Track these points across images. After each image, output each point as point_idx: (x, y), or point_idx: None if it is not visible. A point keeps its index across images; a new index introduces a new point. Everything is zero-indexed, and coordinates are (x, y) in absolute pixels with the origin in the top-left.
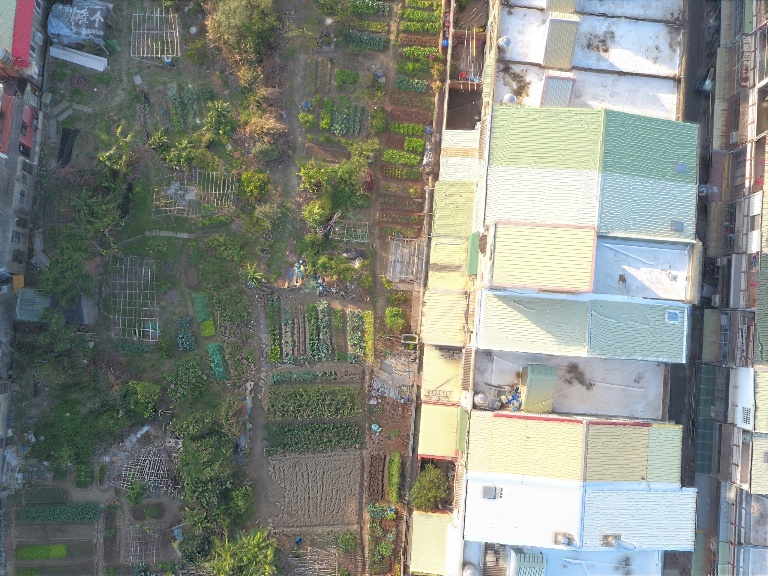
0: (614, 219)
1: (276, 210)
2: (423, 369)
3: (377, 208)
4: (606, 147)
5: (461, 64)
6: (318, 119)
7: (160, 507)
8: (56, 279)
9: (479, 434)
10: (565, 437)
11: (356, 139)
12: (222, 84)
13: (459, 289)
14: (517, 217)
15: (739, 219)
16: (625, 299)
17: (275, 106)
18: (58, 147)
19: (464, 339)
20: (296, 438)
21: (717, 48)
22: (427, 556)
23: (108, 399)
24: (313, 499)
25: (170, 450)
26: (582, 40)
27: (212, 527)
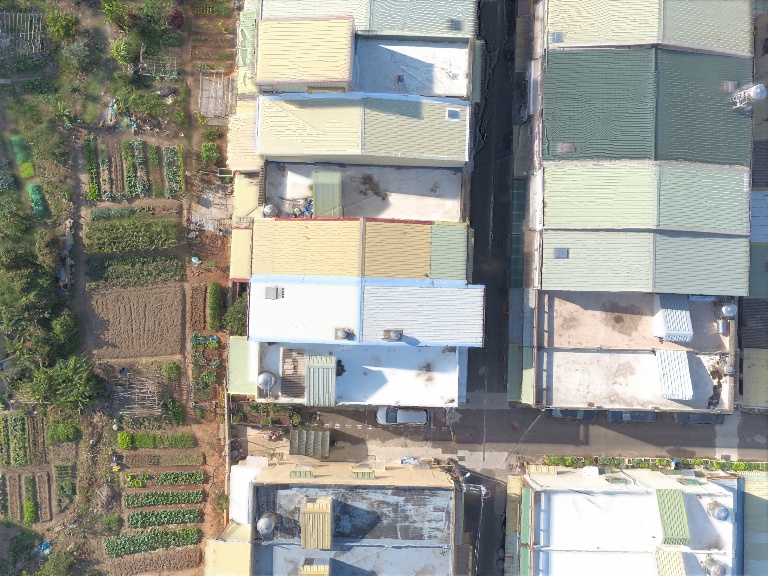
0: (396, 23)
1: (83, 48)
2: (235, 198)
3: (190, 46)
4: None
5: None
6: None
7: None
8: None
9: (263, 239)
10: (345, 236)
11: None
12: None
13: None
14: None
15: (537, 24)
16: (400, 97)
17: None
18: None
19: None
20: (117, 272)
21: None
22: (244, 378)
23: None
24: (136, 331)
25: None
26: None
27: (34, 356)
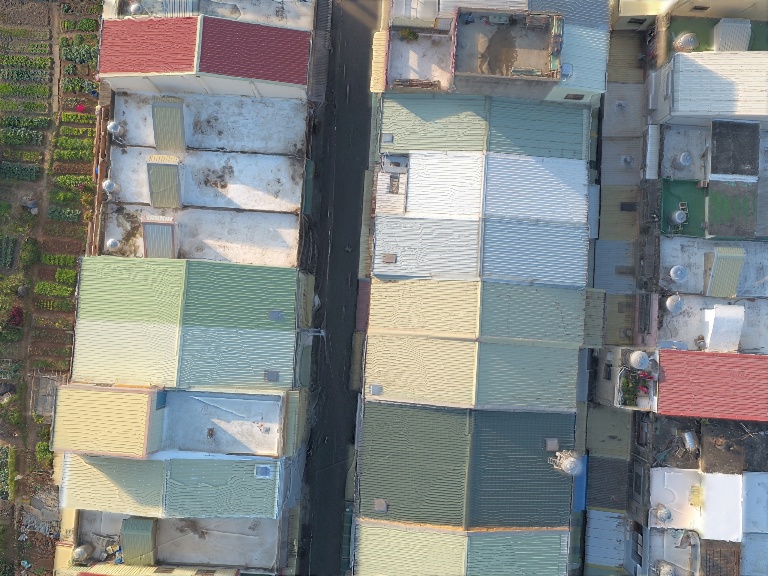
0: (211, 368)
1: None
2: None
3: (28, 341)
4: (187, 300)
5: None
6: None
7: None
8: None
9: None
10: None
11: (8, 272)
12: None
13: None
14: (94, 375)
15: None
16: (206, 456)
17: None
18: None
19: None
20: None
21: (365, 171)
22: None
23: None
24: None
25: None
26: (200, 176)
27: None
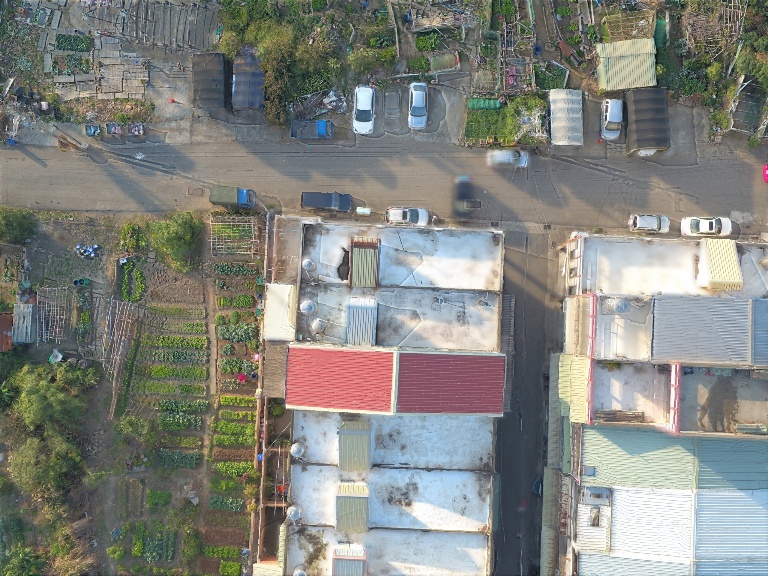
0: None
1: None
2: None
3: None
4: None
5: (275, 485)
6: (130, 544)
7: None
8: None
9: None
10: None
11: (170, 564)
12: (31, 513)
13: None
14: None
15: None
16: None
17: (83, 539)
18: None
19: None
20: None
21: (544, 467)
22: None
23: None
24: None
25: None
26: (383, 494)
27: None
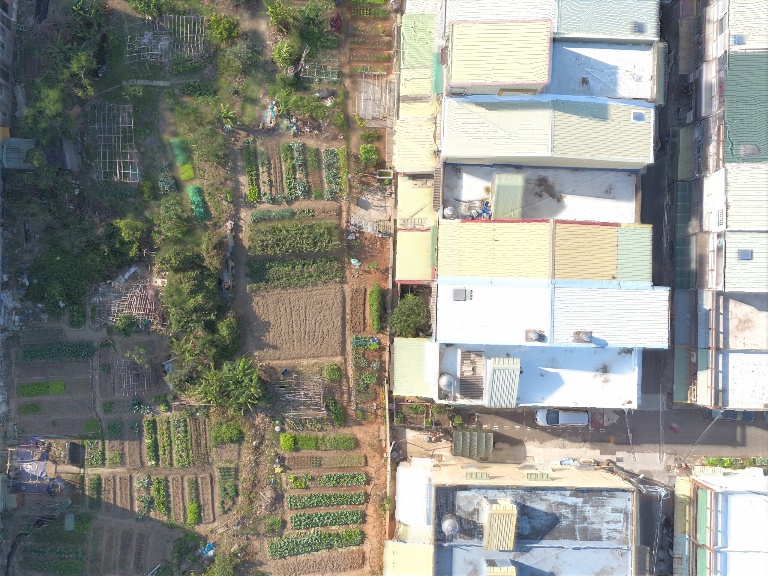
0: (577, 25)
1: (246, 50)
2: (398, 200)
3: (347, 48)
4: None
5: None
6: None
7: (150, 344)
8: (35, 118)
9: (448, 241)
10: (533, 238)
11: None
12: None
13: (429, 116)
14: None
15: (709, 26)
16: (588, 99)
17: None
18: (35, 4)
19: (435, 164)
20: (277, 274)
21: None
22: (409, 380)
23: (94, 239)
24: (297, 332)
25: (157, 290)
26: None
27: (199, 358)
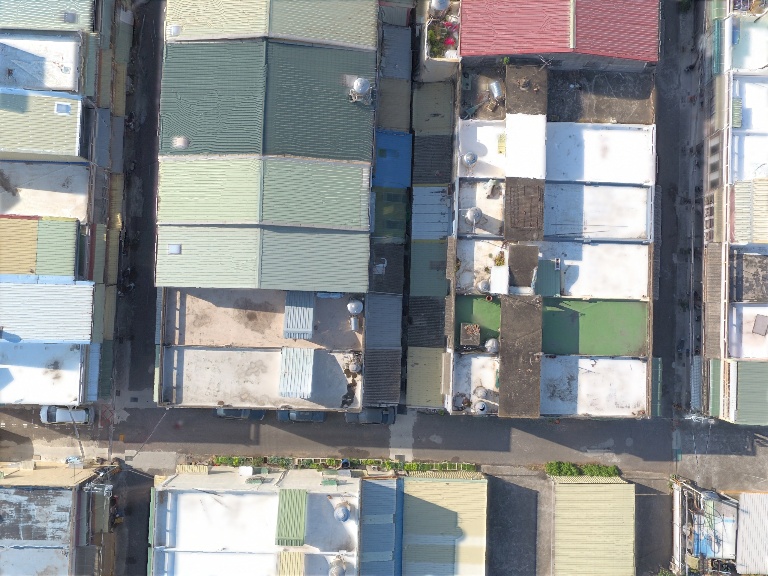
0: None
1: None
2: None
3: None
4: None
5: None
6: None
7: None
8: None
9: None
10: None
11: None
12: None
13: None
14: None
15: None
16: (4, 90)
17: None
18: None
19: None
20: None
21: None
22: None
23: None
24: None
25: None
26: None
27: None
